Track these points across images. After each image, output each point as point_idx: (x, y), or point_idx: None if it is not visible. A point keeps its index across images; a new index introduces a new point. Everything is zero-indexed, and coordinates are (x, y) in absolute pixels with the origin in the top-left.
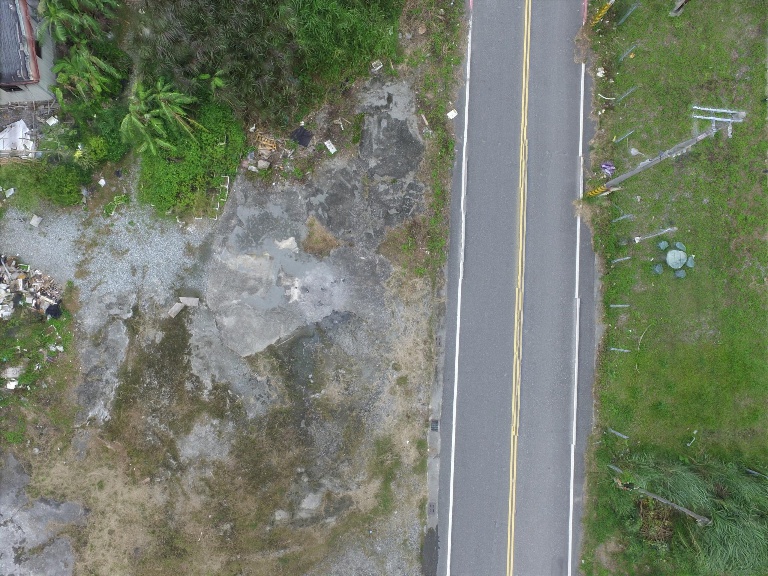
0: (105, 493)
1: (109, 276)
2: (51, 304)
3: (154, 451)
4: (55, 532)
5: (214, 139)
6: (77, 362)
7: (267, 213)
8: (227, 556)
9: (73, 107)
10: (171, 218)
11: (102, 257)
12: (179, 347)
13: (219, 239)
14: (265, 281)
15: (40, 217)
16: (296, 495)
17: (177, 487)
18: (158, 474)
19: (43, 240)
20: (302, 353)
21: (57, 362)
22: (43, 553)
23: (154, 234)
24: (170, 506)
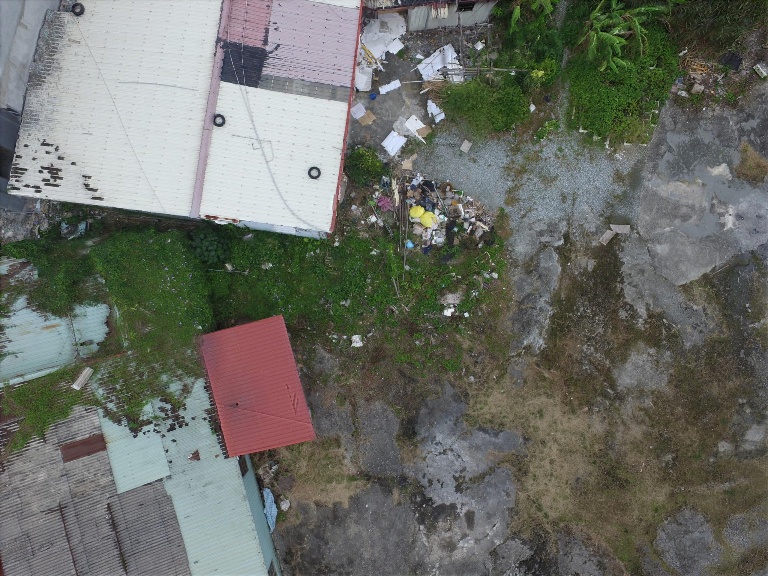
0: (545, 422)
1: (539, 203)
2: (484, 230)
3: (591, 380)
4: (495, 461)
5: (650, 62)
6: (510, 290)
7: (698, 139)
8: (670, 488)
9: (519, 28)
10: (599, 144)
11: (531, 183)
12: (611, 275)
13: (649, 165)
14: (698, 208)
15: (471, 142)
16: (738, 426)
17: (616, 417)
18: (596, 404)
19: (473, 166)
20: (738, 282)
21: (491, 289)
22: (484, 482)
23: (583, 160)
24: (610, 436)
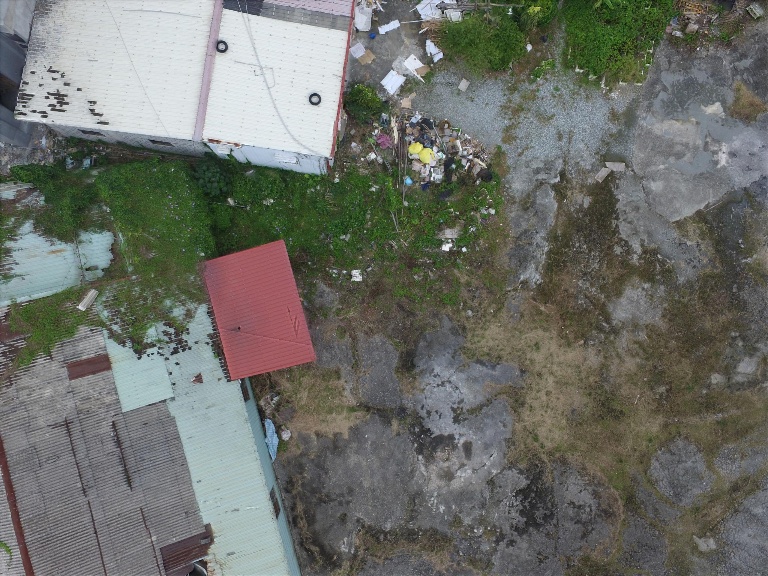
0: (542, 354)
1: (536, 141)
2: (482, 167)
3: (586, 314)
4: (493, 393)
5: (645, 2)
6: (507, 226)
7: (692, 78)
8: (664, 419)
9: None
10: (595, 83)
11: (528, 122)
12: (606, 212)
13: (644, 104)
14: (692, 146)
15: (469, 81)
16: (731, 359)
17: (611, 350)
18: (591, 337)
19: (470, 105)
20: (731, 218)
21: (489, 225)
22: (481, 413)
23: (579, 99)
24: (605, 368)
